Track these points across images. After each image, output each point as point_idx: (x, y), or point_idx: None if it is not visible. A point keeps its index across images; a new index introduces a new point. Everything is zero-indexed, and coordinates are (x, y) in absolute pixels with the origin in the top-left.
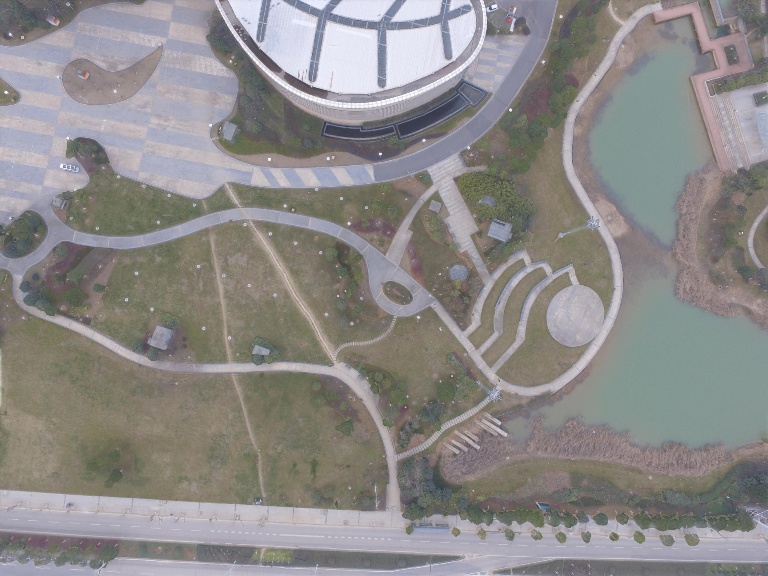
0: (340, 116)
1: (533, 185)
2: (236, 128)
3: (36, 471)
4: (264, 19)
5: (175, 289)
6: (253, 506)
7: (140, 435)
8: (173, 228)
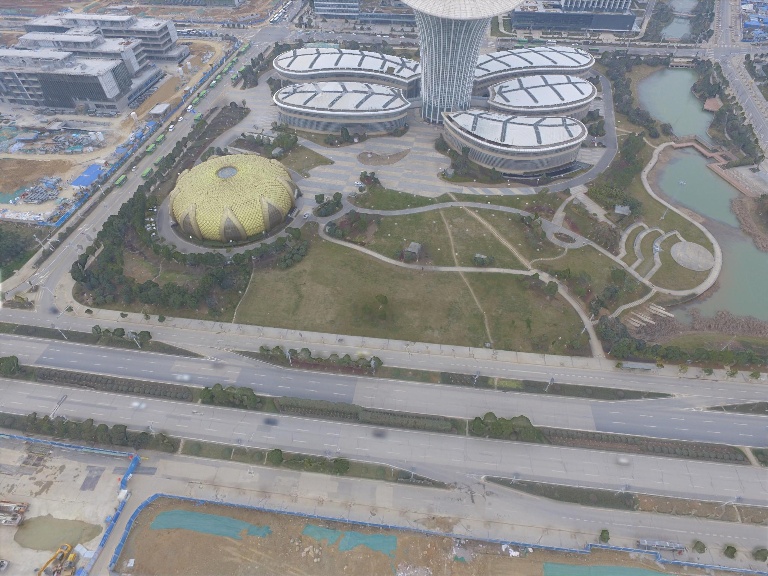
0: (512, 167)
1: (634, 197)
2: (454, 170)
3: (318, 319)
4: (475, 124)
5: (420, 231)
6: (484, 349)
7: (397, 299)
8: (417, 208)
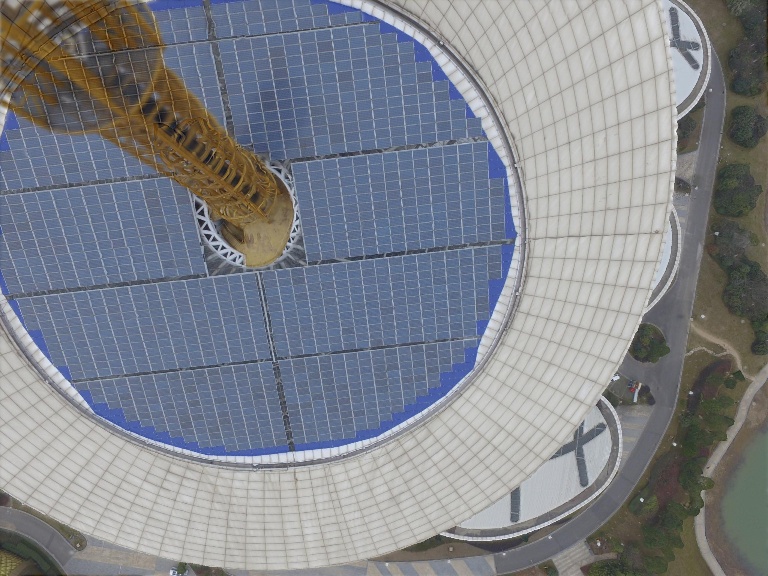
0: None
1: (667, 571)
2: None
3: None
4: None
5: None
6: None
7: None
8: None
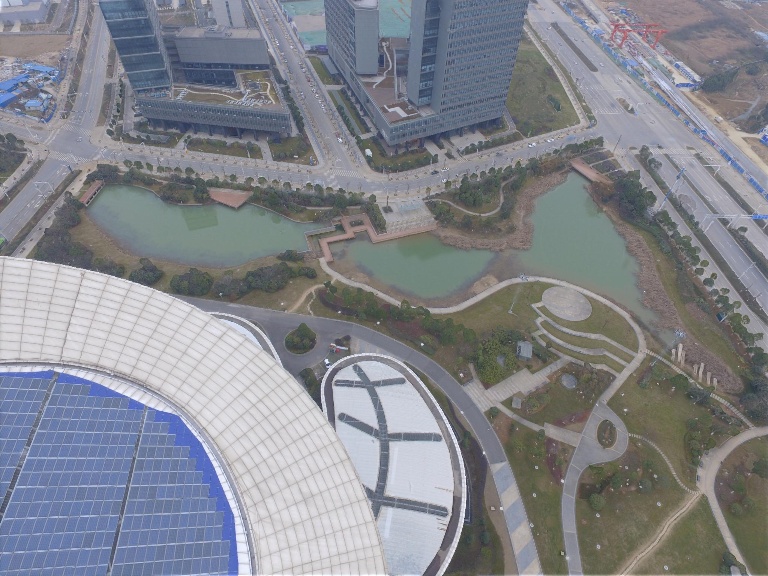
0: None
1: (476, 331)
2: None
3: None
4: None
5: None
6: None
7: None
8: None
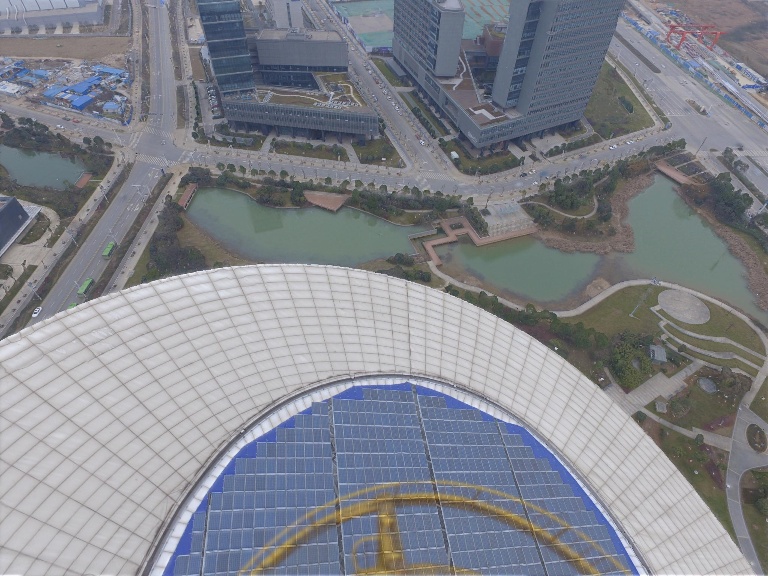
0: None
1: None
2: None
3: None
4: None
5: None
6: None
7: None
8: None
